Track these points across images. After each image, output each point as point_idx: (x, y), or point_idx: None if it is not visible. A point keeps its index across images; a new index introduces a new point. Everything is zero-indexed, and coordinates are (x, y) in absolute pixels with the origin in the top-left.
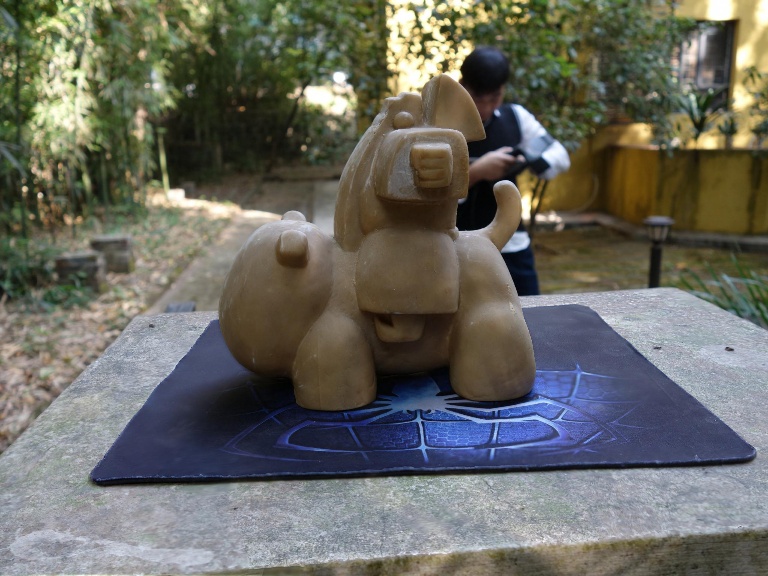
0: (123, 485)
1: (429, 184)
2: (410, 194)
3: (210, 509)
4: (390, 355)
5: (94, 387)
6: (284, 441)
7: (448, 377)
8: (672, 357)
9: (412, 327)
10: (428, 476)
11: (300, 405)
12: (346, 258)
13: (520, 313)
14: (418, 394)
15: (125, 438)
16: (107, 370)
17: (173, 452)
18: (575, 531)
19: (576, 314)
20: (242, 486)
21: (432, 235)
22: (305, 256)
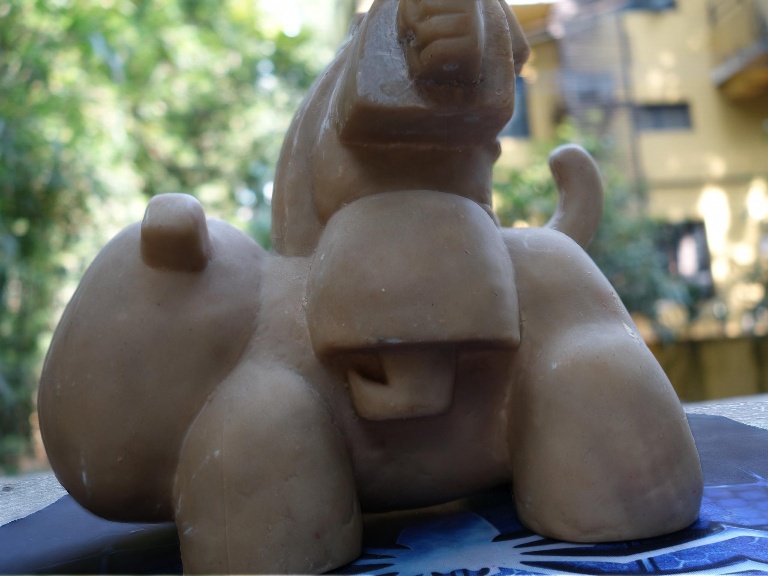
0: None
1: (439, 45)
2: (402, 96)
3: None
4: (387, 458)
5: None
6: None
7: (510, 507)
8: None
9: (428, 381)
10: None
11: None
12: (289, 265)
13: None
14: (453, 541)
15: None
16: None
17: None
18: None
19: (690, 422)
20: None
21: (453, 195)
22: (197, 242)
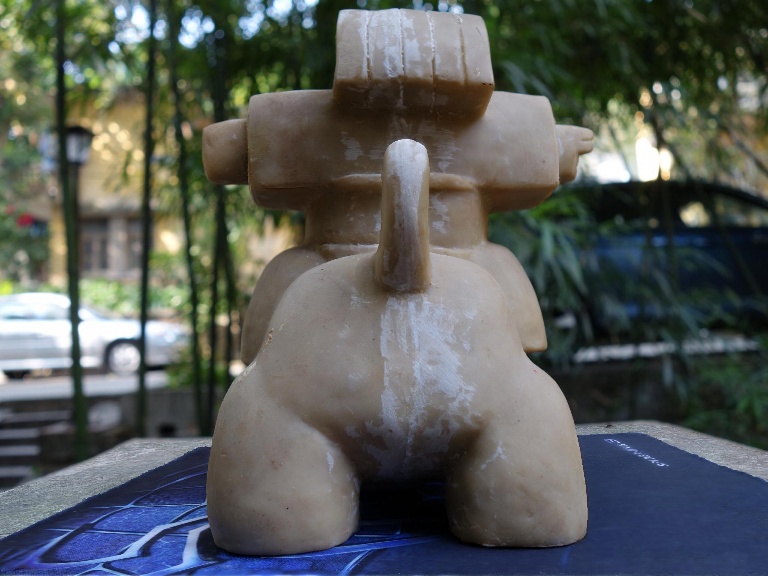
0: None
1: None
2: None
3: None
4: None
5: None
6: None
7: None
8: None
9: None
10: None
11: None
12: None
13: (256, 386)
14: None
15: None
16: None
17: None
18: None
19: None
20: None
21: None
22: None
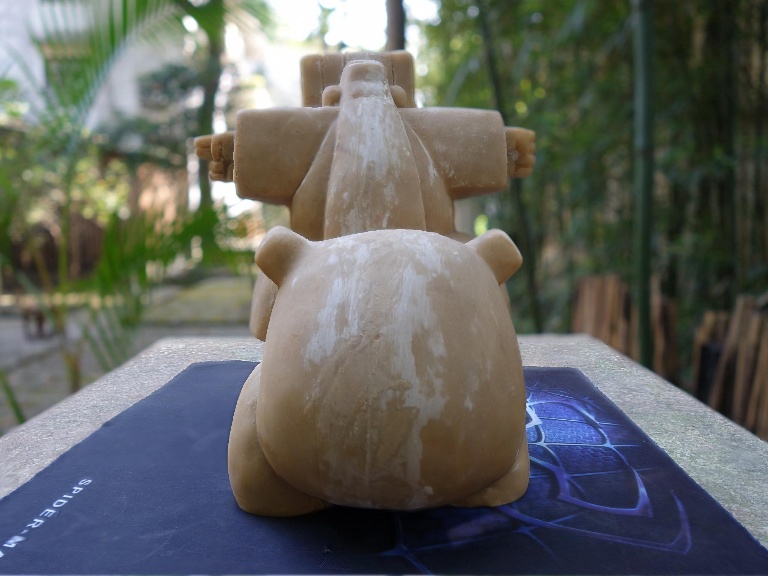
0: None
1: None
2: None
3: None
4: None
5: None
6: (632, 510)
7: None
8: None
9: None
10: None
11: (511, 501)
12: None
13: None
14: None
15: None
16: None
17: None
18: (713, 417)
19: (228, 367)
20: (761, 539)
21: None
22: None
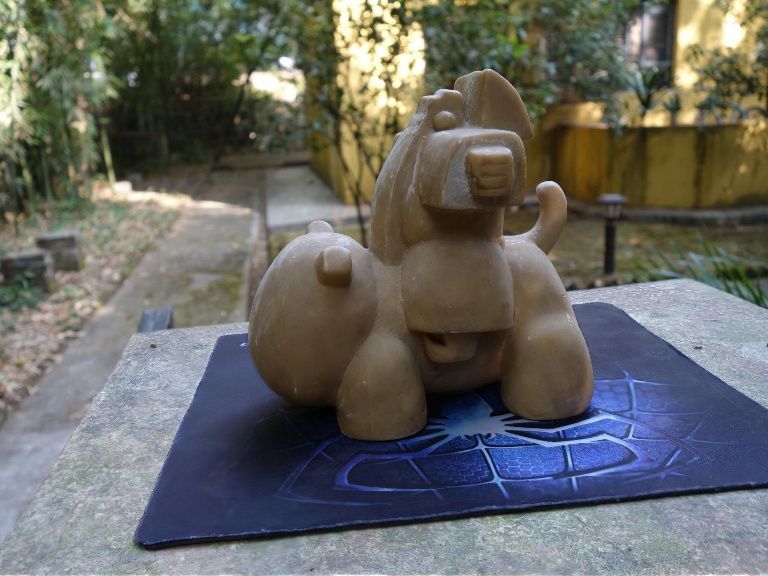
0: (175, 547)
1: (491, 193)
2: (465, 203)
3: (283, 572)
4: (439, 375)
5: (108, 424)
6: (343, 481)
7: (497, 393)
8: (717, 358)
9: (466, 345)
10: (513, 515)
11: (347, 435)
12: (389, 273)
13: None
14: (470, 415)
15: (162, 487)
16: (117, 402)
17: (223, 502)
18: (696, 574)
19: (602, 313)
20: (311, 540)
21: (485, 245)
22: (350, 274)
